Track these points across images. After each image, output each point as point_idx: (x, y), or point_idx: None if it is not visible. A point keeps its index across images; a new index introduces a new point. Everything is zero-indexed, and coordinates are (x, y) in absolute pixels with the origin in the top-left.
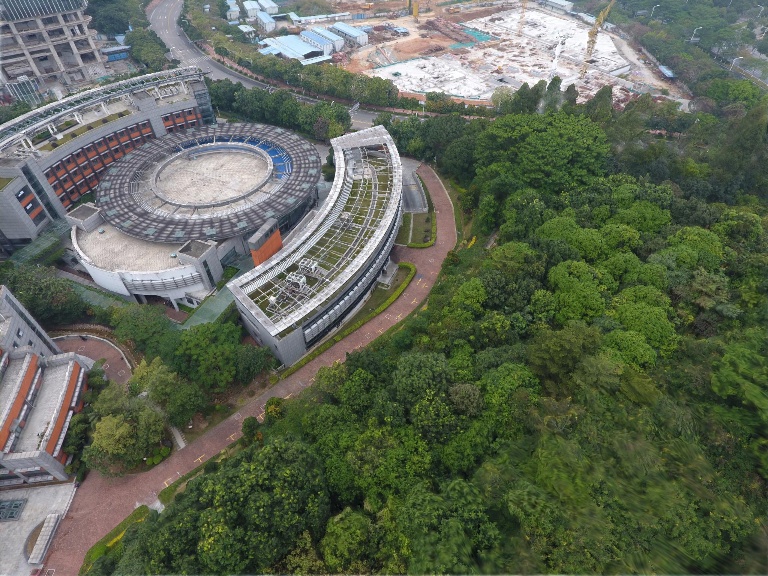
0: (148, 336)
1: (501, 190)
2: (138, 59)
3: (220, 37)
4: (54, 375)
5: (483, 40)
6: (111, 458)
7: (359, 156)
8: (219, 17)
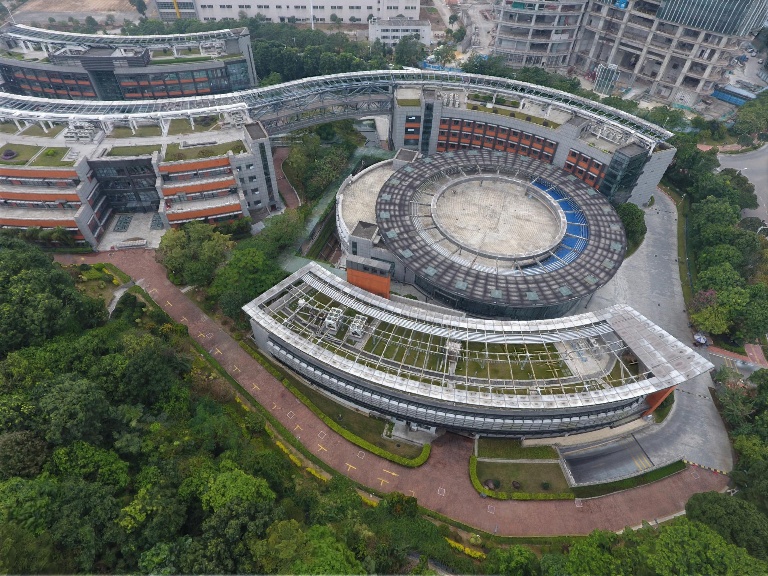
0: (264, 233)
1: None
2: None
3: None
4: (231, 199)
5: None
6: (162, 249)
7: None
8: None
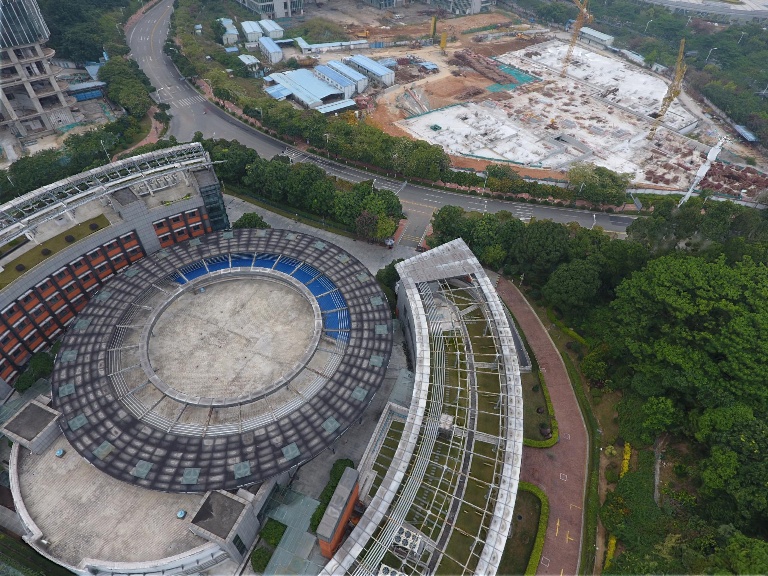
0: None
1: (681, 390)
2: (115, 101)
3: (218, 73)
4: None
5: (524, 81)
6: None
7: (436, 289)
8: (214, 41)
